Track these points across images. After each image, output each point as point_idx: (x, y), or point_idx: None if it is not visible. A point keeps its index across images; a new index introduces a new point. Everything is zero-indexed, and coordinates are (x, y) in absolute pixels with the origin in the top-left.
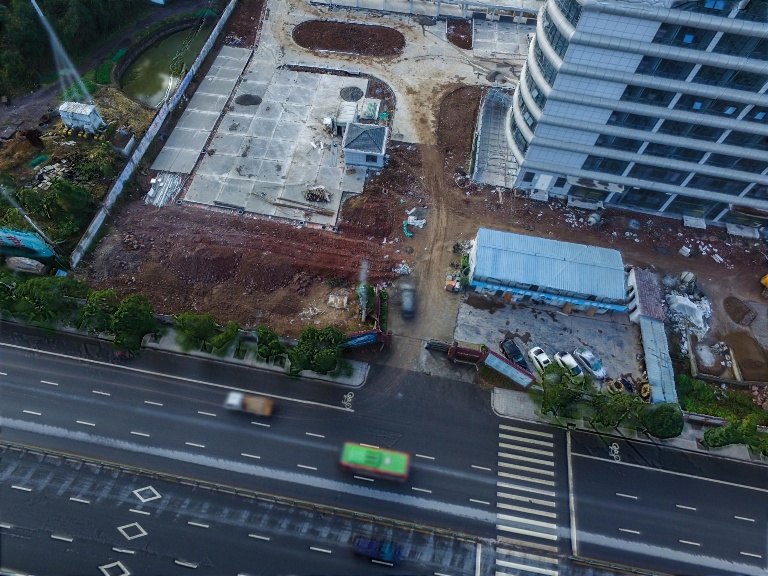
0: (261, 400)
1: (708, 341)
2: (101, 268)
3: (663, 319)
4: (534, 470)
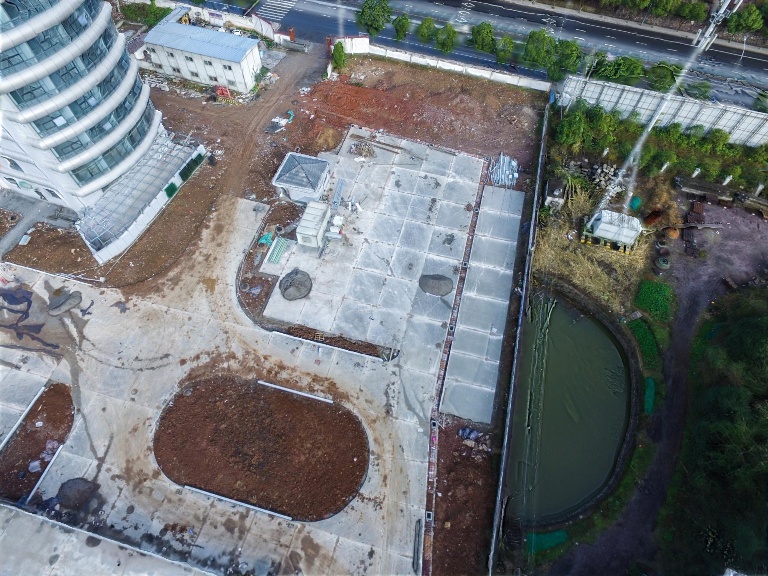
0: (409, 41)
1: None
2: None
3: None
4: (272, 7)
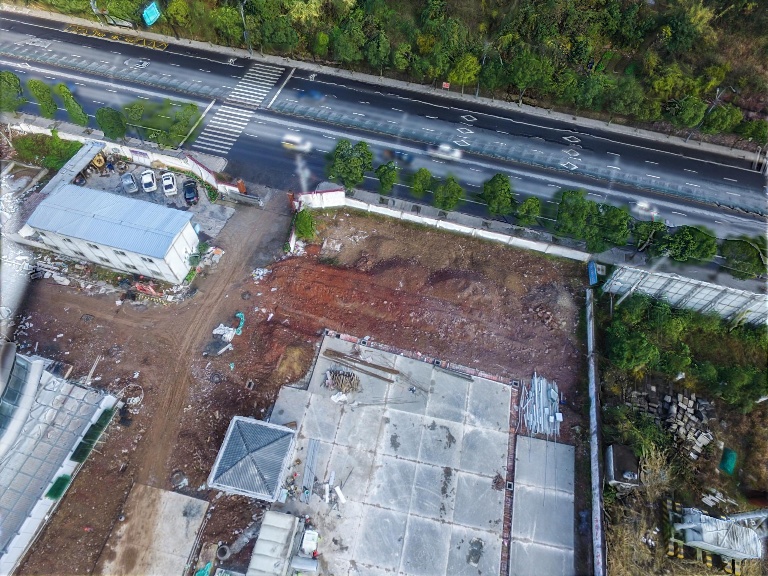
0: (397, 180)
1: (5, 193)
2: None
3: None
4: (217, 132)
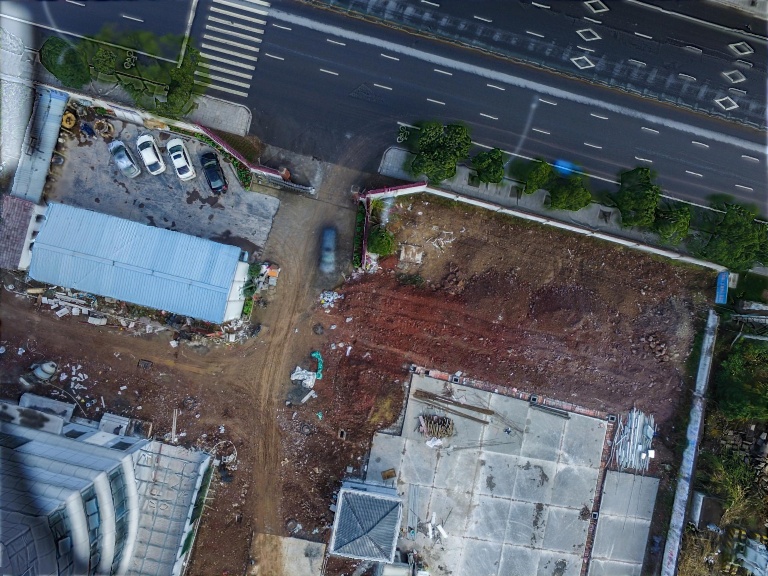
0: (490, 141)
1: None
2: (681, 310)
3: (8, 197)
4: (221, 50)
